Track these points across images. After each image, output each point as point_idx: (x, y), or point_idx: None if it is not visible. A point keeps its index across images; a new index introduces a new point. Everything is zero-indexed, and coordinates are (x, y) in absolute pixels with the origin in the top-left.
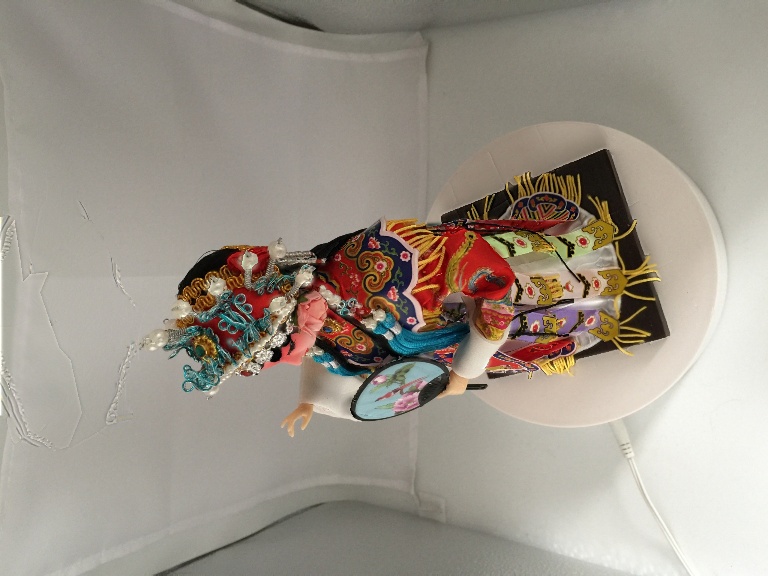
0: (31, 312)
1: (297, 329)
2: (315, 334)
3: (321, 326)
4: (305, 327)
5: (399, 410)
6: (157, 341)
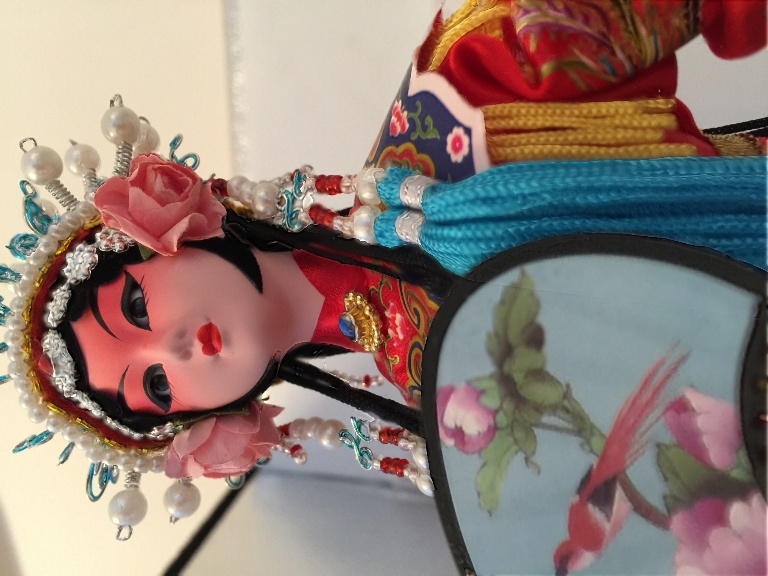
0: None
1: None
2: (246, 298)
3: (183, 228)
4: None
5: None
6: None
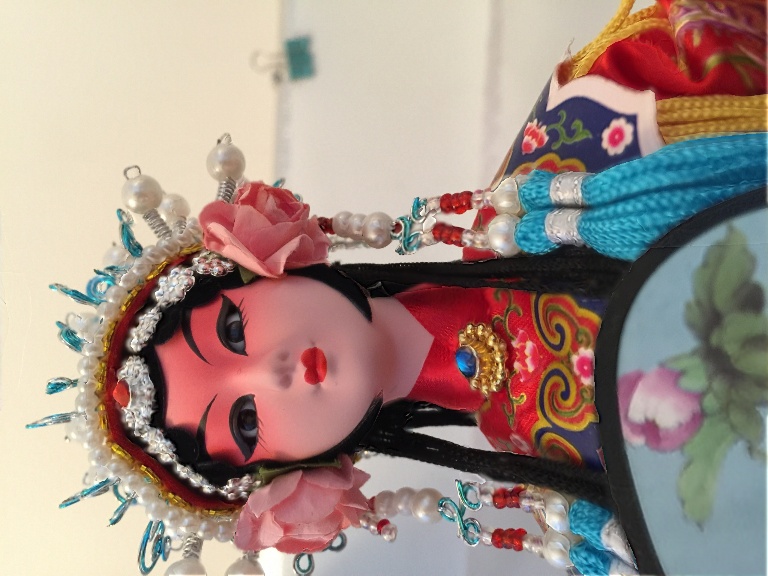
0: None
1: (239, 273)
2: (354, 325)
3: (293, 247)
4: None
5: None
6: (85, 428)
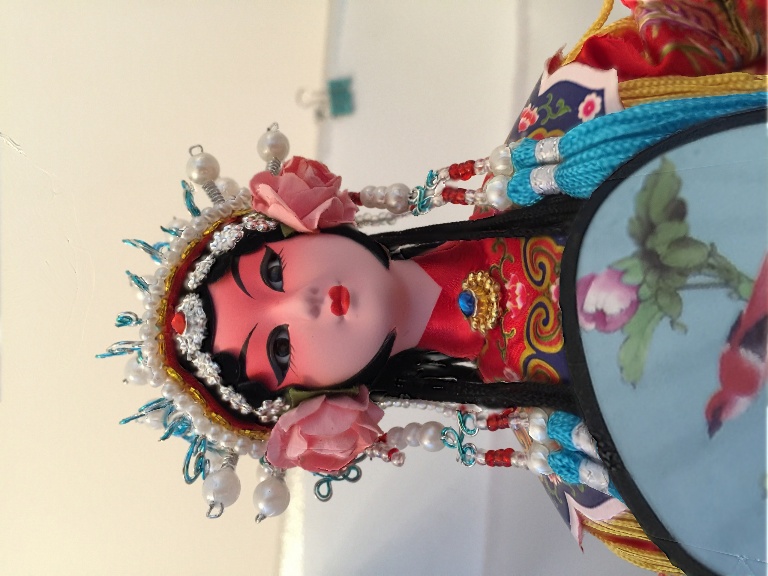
0: (56, 373)
1: None
2: (374, 271)
3: (326, 207)
4: (261, 192)
5: None
6: None
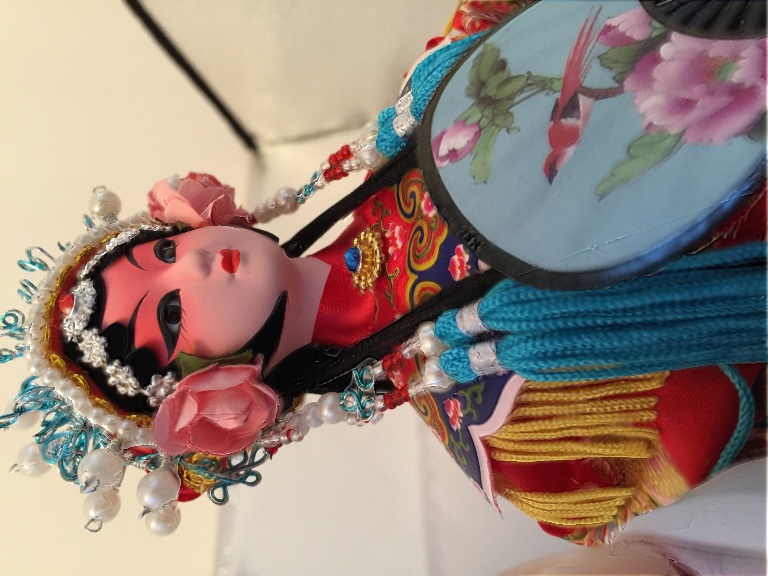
0: None
1: (176, 228)
2: None
3: (219, 199)
4: (158, 198)
5: (748, 121)
6: None
